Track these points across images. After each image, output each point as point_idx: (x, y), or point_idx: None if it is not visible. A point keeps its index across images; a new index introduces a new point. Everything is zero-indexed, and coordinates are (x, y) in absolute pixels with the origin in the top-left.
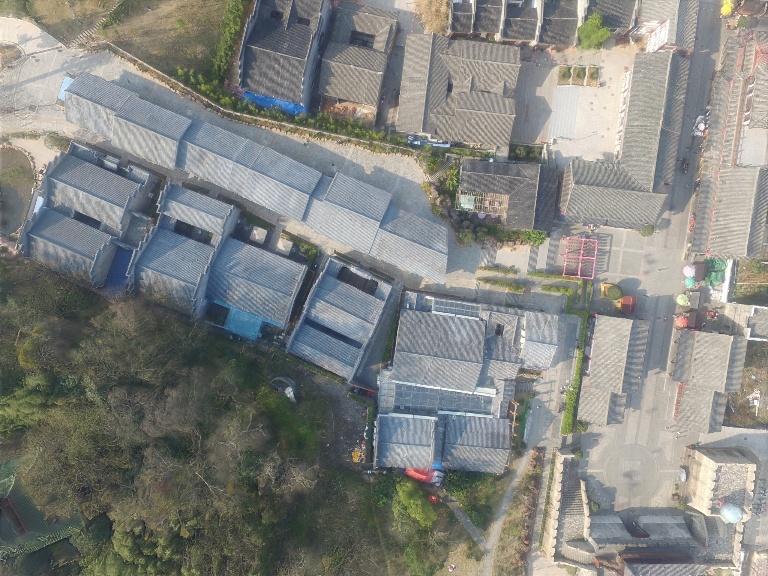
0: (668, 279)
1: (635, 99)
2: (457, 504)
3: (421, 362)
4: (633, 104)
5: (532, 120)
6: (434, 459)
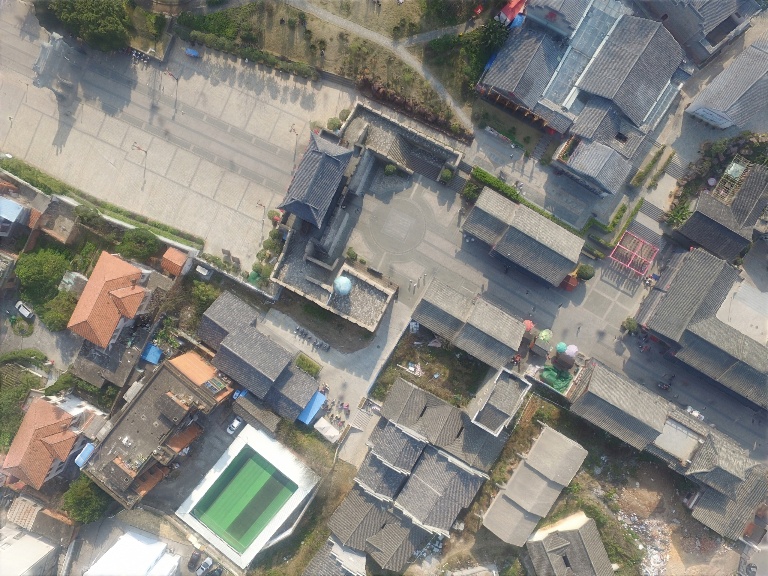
0: (567, 332)
1: (767, 352)
2: (461, 32)
3: (637, 44)
4: (763, 349)
5: (762, 271)
6: (525, 24)
